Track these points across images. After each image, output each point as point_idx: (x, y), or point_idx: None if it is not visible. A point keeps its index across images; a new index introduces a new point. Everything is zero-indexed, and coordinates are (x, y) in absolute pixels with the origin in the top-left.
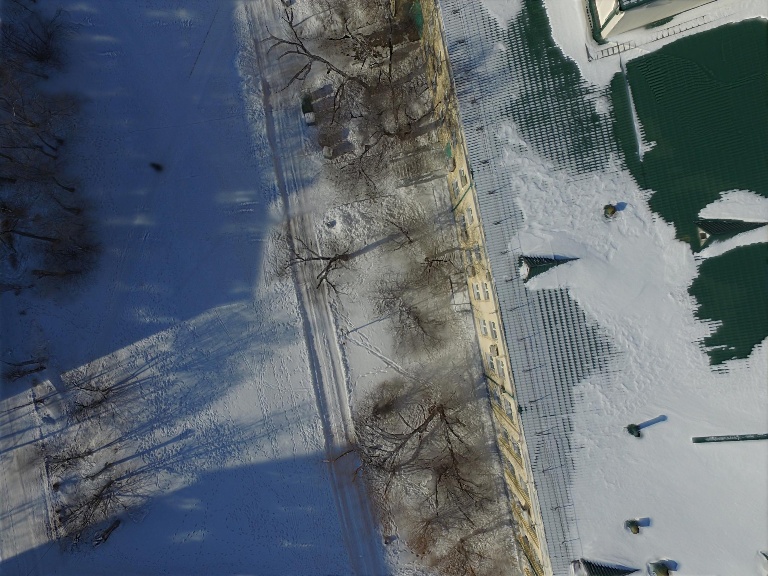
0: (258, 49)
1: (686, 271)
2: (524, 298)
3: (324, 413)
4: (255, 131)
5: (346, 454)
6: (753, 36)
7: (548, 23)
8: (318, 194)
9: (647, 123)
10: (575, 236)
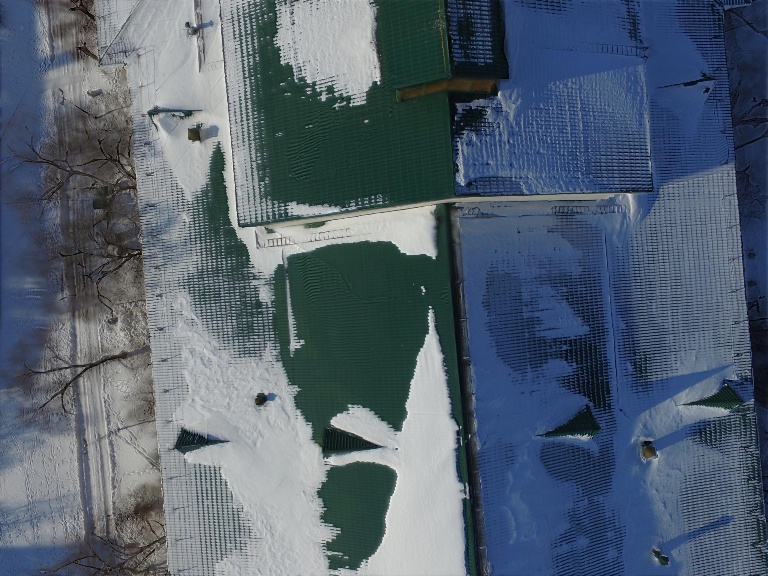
0: (61, 136)
1: (317, 474)
2: (183, 469)
3: (88, 505)
4: (49, 219)
5: (77, 561)
6: (383, 260)
7: (227, 202)
8: (105, 288)
9: (299, 320)
10: (230, 418)
